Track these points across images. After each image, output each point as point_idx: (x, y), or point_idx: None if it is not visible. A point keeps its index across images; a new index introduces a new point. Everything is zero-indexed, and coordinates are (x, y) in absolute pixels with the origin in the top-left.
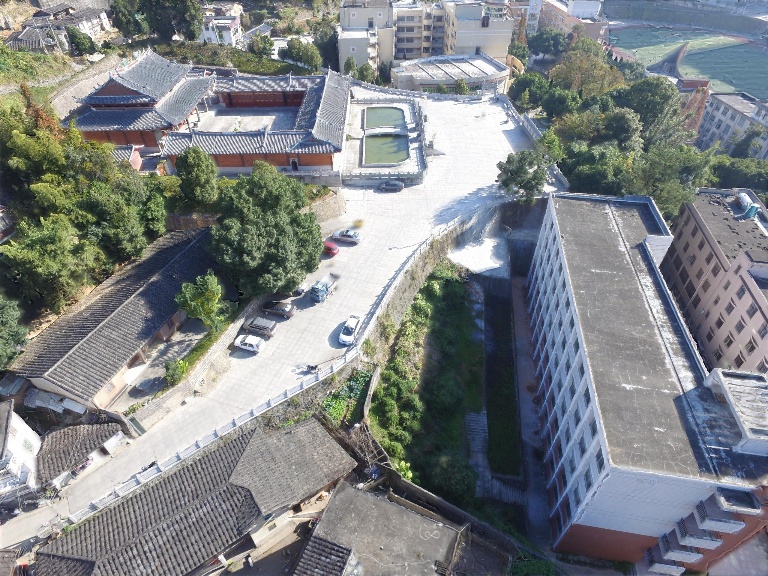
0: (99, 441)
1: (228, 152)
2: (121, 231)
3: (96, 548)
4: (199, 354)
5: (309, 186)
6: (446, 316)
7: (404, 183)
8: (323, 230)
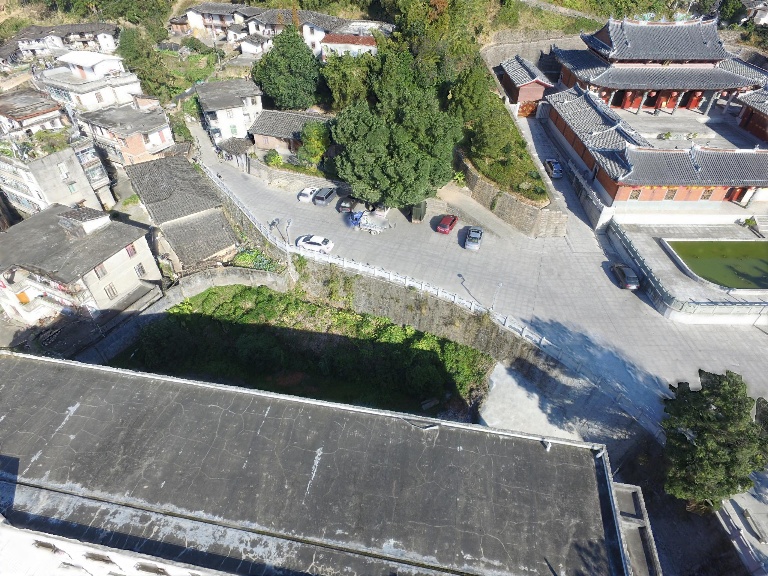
0: (235, 151)
1: (568, 121)
2: (377, 86)
3: (166, 162)
4: (291, 167)
5: (531, 179)
6: (387, 368)
7: (647, 291)
8: (481, 219)
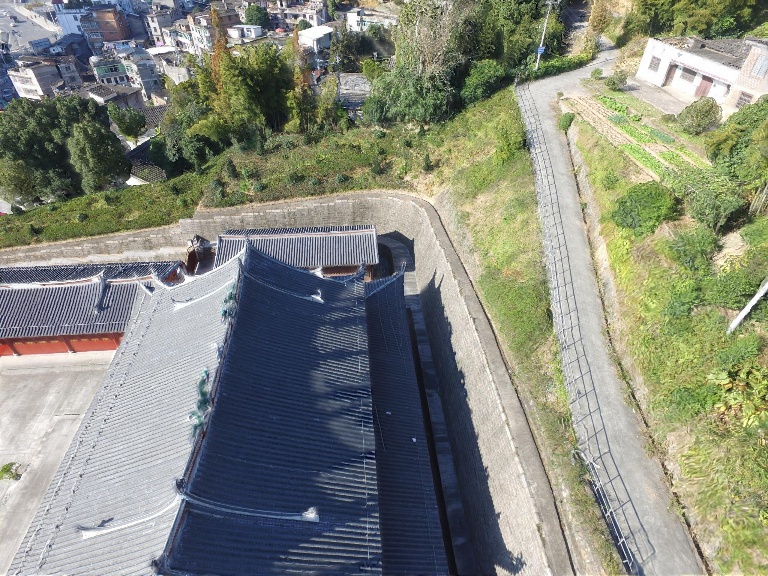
0: None
1: (53, 267)
2: None
3: None
4: None
5: None
6: None
7: None
8: None
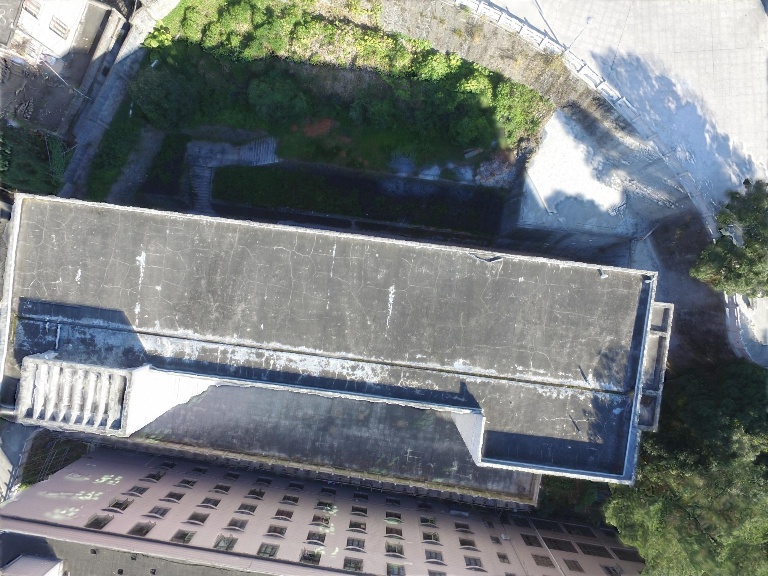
0: None
1: None
2: None
3: None
4: None
5: None
6: (427, 112)
7: None
8: None
